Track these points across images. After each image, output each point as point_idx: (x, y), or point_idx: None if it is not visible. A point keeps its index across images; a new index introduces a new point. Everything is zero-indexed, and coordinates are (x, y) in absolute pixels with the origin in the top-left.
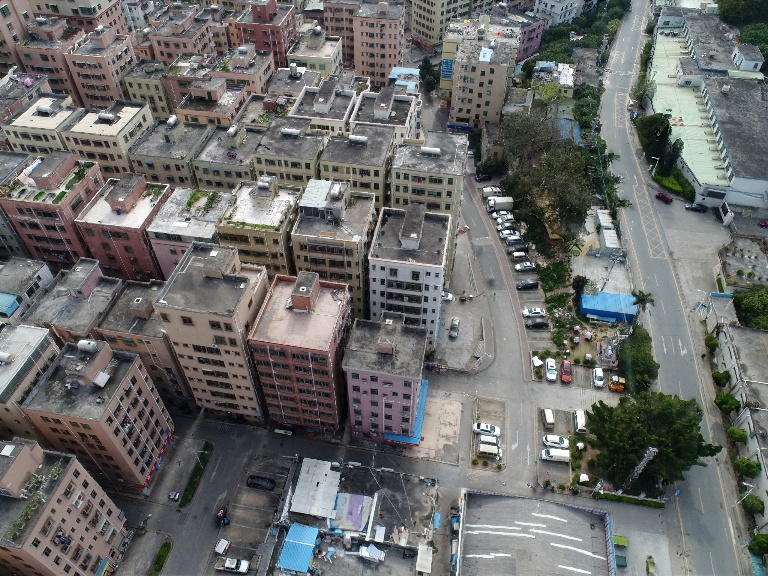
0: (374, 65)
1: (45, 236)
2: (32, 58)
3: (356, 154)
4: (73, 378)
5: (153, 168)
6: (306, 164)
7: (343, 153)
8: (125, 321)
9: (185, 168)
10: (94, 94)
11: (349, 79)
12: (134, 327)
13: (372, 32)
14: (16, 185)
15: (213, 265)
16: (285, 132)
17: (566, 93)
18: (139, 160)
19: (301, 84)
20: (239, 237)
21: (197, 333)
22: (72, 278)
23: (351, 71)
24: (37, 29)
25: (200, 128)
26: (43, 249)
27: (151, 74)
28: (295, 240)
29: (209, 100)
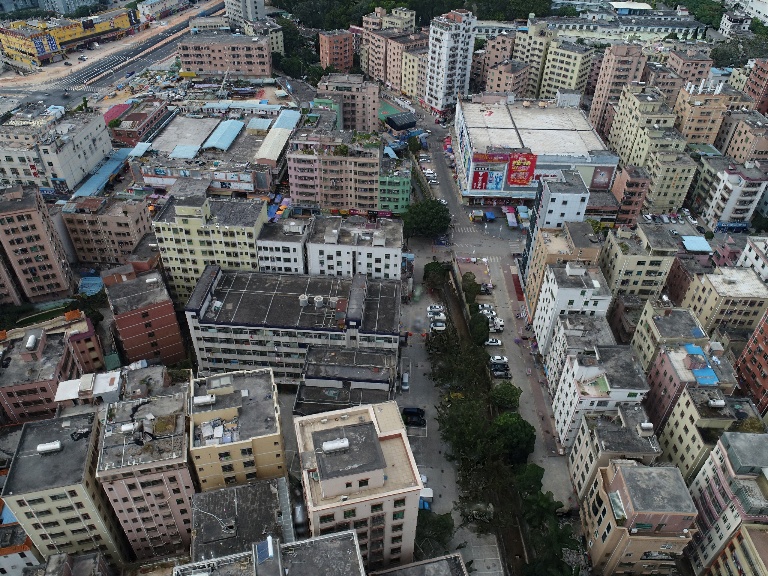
0: None
1: None
2: None
3: None
4: None
5: None
6: None
7: None
8: None
9: None
10: None
11: None
12: None
13: None
14: None
15: None
16: None
17: None
18: None
19: None
20: None
21: None
22: None
23: None
24: None
25: None
26: None
27: None
28: None
29: None
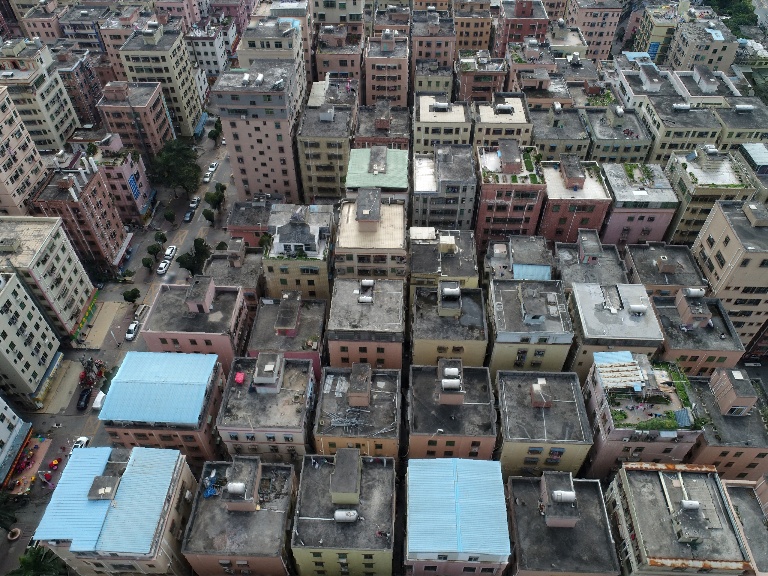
0: (588, 52)
1: (506, 217)
2: (330, 64)
3: (751, 121)
4: (701, 320)
5: (554, 150)
6: (713, 133)
7: (739, 121)
8: (656, 277)
9: (586, 147)
10: (382, 95)
11: (627, 63)
12: (669, 281)
13: (594, 21)
14: (484, 172)
15: (763, 216)
16: (678, 107)
17: (766, 65)
18: (543, 144)
19: (587, 70)
20: (712, 197)
21: (762, 274)
22: (587, 246)
23: (621, 56)
24: (329, 36)
25: (569, 112)
26: (494, 230)
27: (437, 72)
28: (765, 194)
29: (539, 89)
